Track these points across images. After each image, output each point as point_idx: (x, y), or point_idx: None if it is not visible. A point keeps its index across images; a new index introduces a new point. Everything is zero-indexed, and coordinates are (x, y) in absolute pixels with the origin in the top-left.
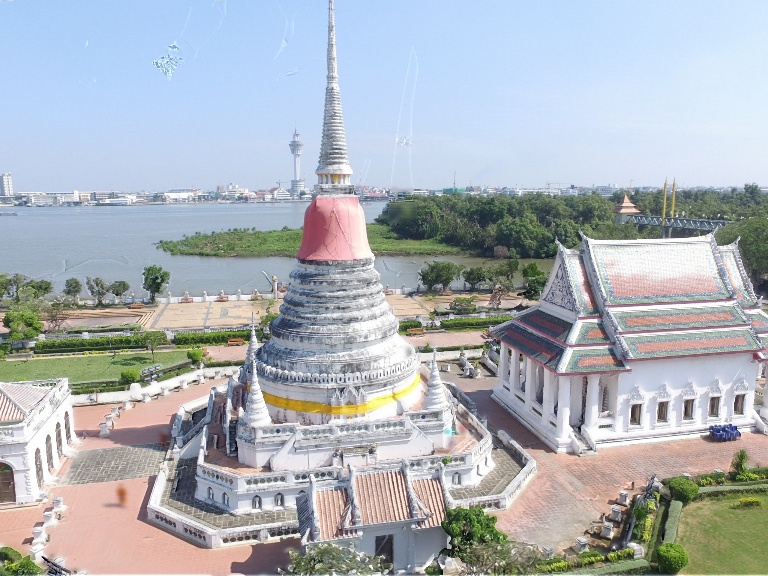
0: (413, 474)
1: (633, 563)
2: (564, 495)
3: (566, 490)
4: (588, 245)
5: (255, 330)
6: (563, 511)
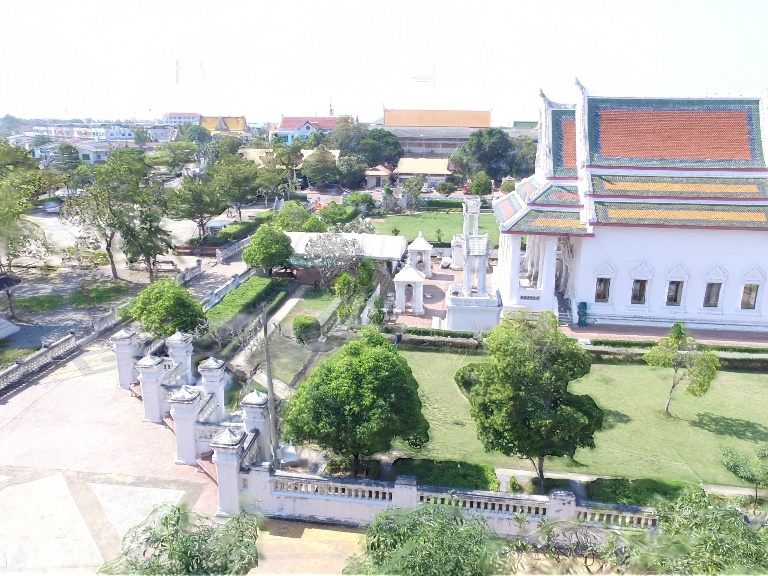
0: None
1: None
2: None
3: None
4: (762, 98)
5: None
6: None
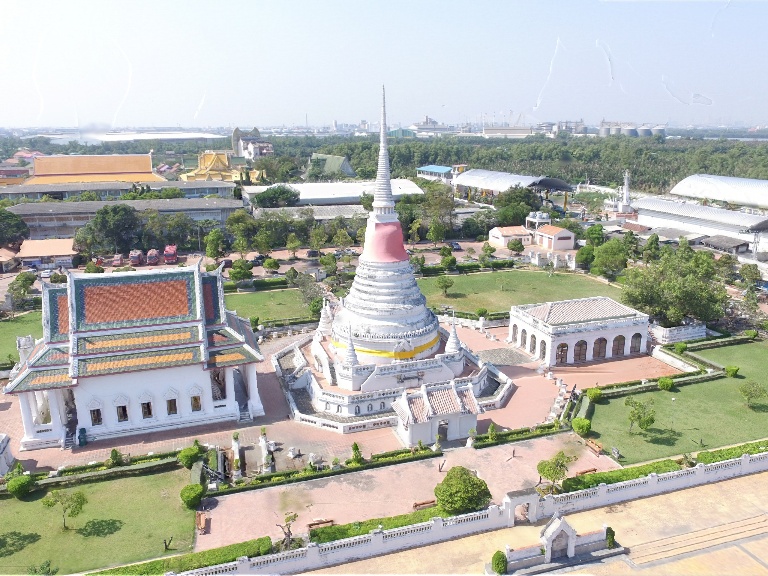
0: (339, 302)
1: (268, 320)
2: (267, 352)
3: (264, 354)
4: None
5: (578, 481)
6: (272, 347)
